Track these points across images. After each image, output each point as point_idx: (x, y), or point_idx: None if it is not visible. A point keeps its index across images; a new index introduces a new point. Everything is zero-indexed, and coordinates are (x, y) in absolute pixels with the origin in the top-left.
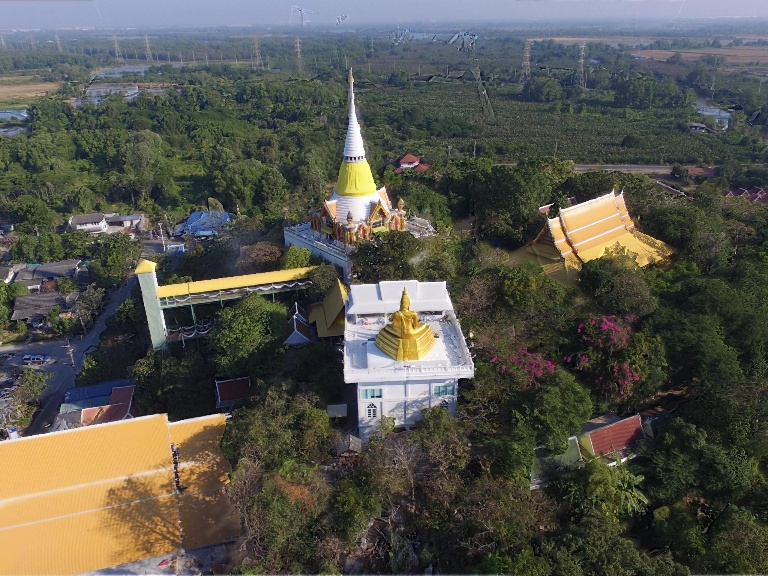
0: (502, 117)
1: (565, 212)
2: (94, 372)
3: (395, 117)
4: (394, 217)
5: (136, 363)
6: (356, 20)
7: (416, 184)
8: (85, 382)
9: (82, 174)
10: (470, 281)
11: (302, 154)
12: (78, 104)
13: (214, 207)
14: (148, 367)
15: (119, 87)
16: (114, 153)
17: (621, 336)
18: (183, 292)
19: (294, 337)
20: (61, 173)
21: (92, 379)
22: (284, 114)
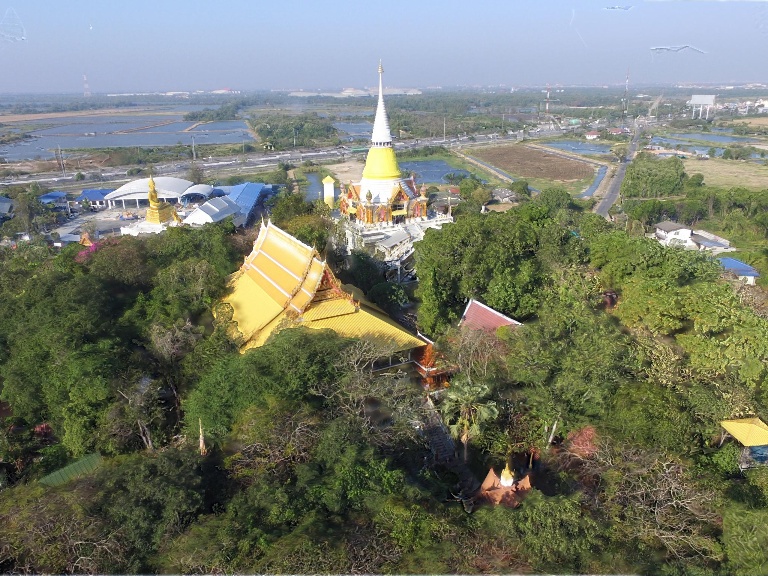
0: None
1: None
2: None
3: None
4: None
5: None
6: None
7: None
8: None
9: None
10: None
11: None
12: None
13: None
14: None
15: None
16: None
17: (82, 257)
18: None
19: None
20: None
21: None
22: None
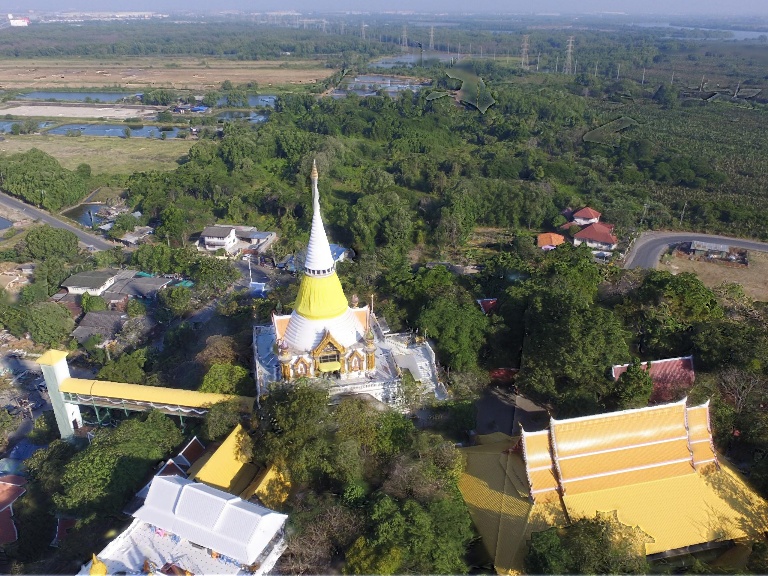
0: (766, 164)
1: (562, 425)
2: (43, 433)
3: (623, 147)
4: (354, 353)
5: (35, 452)
6: (462, 66)
7: (461, 291)
8: (33, 440)
9: (267, 175)
10: (325, 514)
11: (452, 193)
12: (320, 98)
13: (299, 251)
14: (38, 462)
15: (374, 81)
16: (297, 159)
17: None
18: (85, 391)
19: (146, 492)
20: (248, 173)
21: (40, 439)
22: (496, 130)
